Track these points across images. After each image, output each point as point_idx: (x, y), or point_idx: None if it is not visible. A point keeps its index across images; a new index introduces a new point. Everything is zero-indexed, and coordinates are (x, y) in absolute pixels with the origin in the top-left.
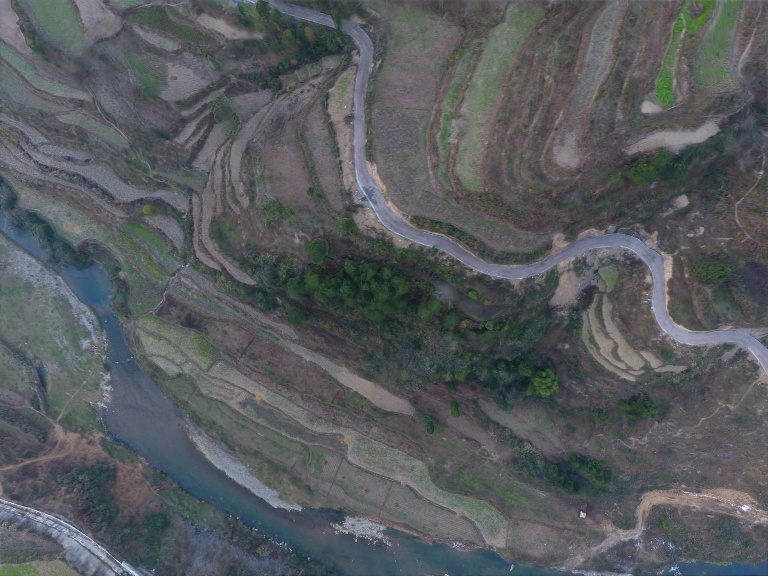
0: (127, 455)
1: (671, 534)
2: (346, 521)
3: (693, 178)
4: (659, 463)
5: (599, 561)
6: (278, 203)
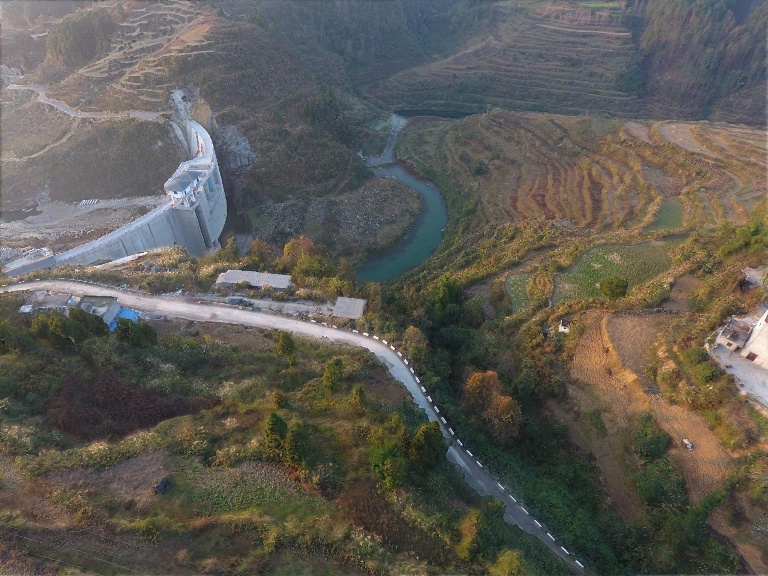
0: None
1: None
2: None
3: (46, 51)
4: None
5: None
6: None
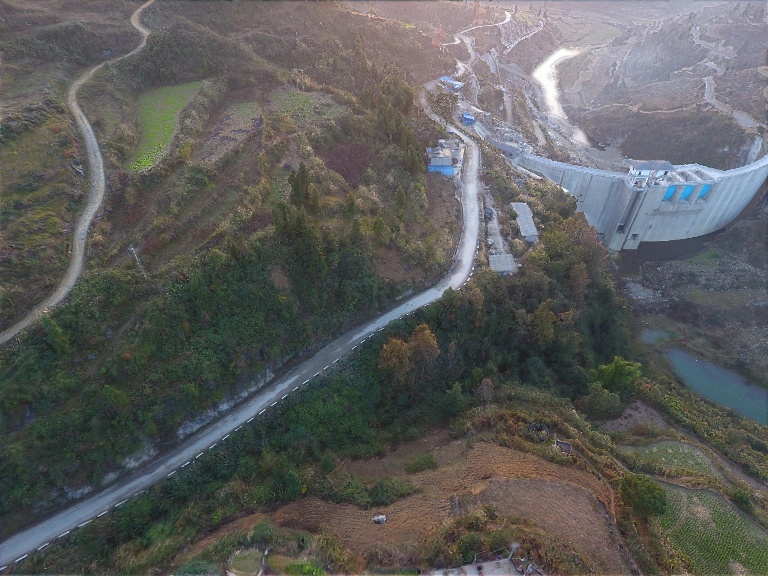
0: (556, 49)
1: None
2: None
3: None
4: None
5: None
6: (681, 27)
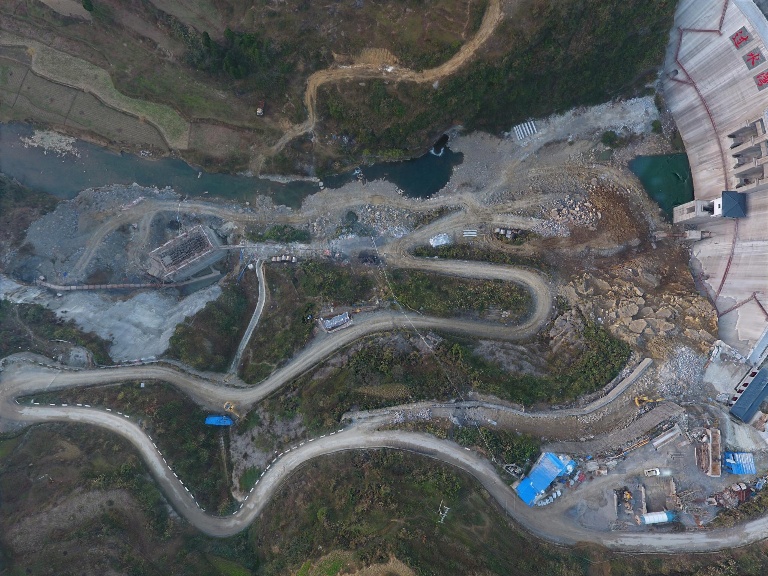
0: None
1: (343, 125)
2: (35, 135)
3: None
4: (302, 23)
5: (279, 159)
6: None
